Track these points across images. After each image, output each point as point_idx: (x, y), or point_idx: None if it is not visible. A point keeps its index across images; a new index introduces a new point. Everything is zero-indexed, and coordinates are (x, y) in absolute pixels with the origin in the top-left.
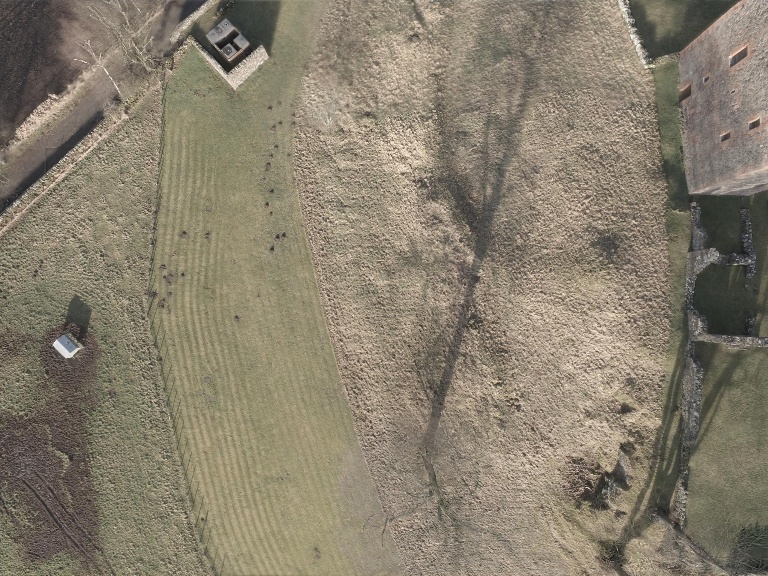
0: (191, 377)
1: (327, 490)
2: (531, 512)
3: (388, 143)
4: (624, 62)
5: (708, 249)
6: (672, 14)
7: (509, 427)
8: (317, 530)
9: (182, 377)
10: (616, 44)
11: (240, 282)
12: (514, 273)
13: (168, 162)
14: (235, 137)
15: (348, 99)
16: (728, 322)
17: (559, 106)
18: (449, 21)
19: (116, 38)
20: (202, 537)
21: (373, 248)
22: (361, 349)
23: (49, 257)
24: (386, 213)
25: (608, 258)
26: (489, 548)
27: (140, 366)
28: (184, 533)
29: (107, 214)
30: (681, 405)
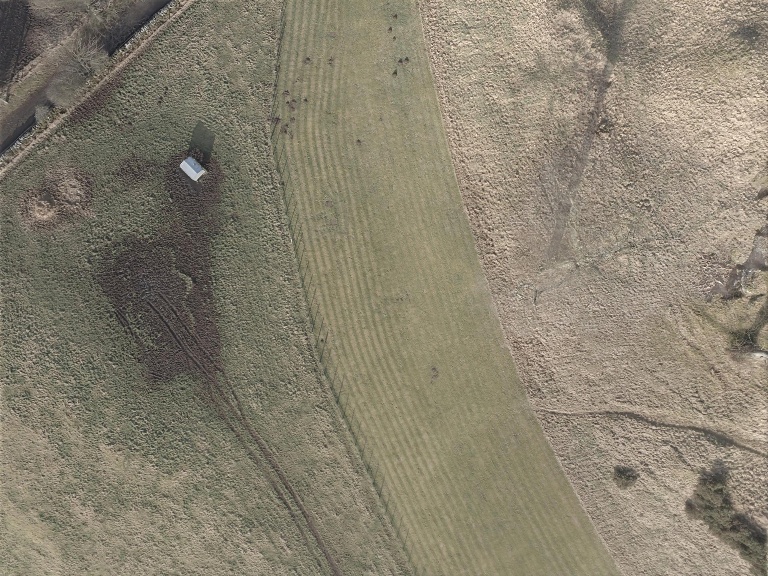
0: (313, 201)
1: (447, 309)
2: (659, 312)
3: None
4: None
5: None
6: None
7: (639, 228)
8: (436, 350)
9: (304, 201)
10: None
11: (362, 107)
12: (647, 74)
13: None
14: None
15: None
16: None
17: None
18: None
19: None
20: (322, 358)
21: (498, 67)
22: (483, 169)
23: (174, 84)
24: (512, 31)
25: (750, 45)
26: (613, 354)
27: (262, 191)
28: (304, 354)
29: (231, 42)
30: None
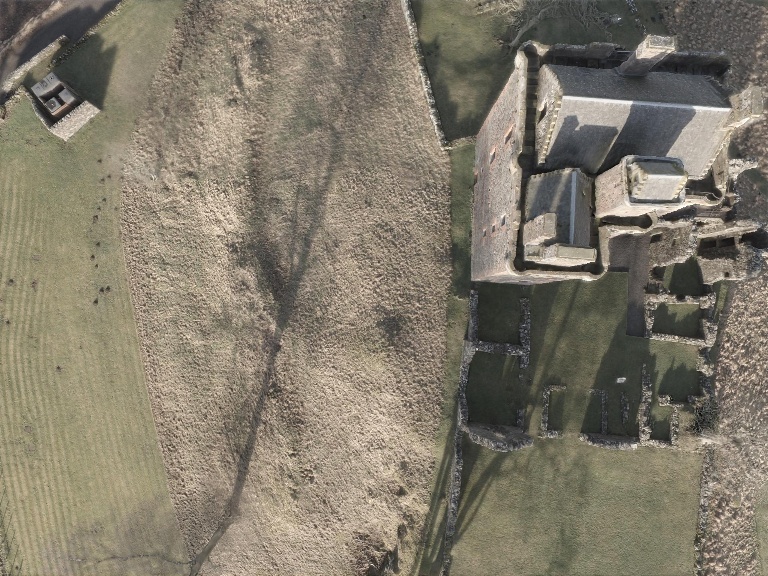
0: (12, 425)
1: (139, 546)
2: None
3: (205, 205)
4: (423, 142)
5: (469, 342)
6: (474, 96)
7: (302, 498)
8: None
9: (3, 424)
10: (417, 123)
11: (63, 333)
12: (311, 345)
13: None
14: (64, 188)
15: (173, 157)
16: (500, 412)
17: (359, 182)
18: (267, 87)
19: None
20: None
21: (191, 307)
22: (177, 407)
23: None
24: (204, 274)
25: (389, 340)
26: None
27: None
28: None
29: None
30: (448, 493)
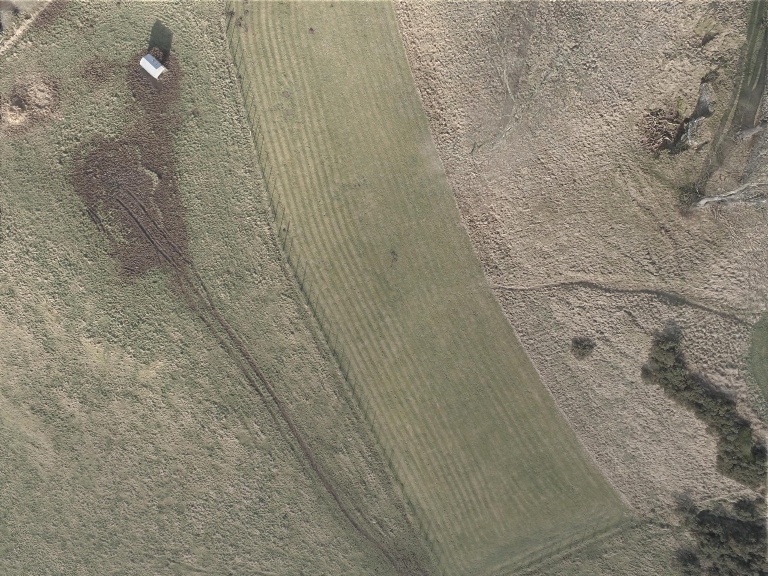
0: (269, 92)
1: (403, 192)
2: (608, 176)
3: None
4: None
5: None
6: None
7: (586, 90)
8: (394, 233)
9: (261, 93)
10: None
11: None
12: None
13: None
14: None
15: None
16: None
17: None
18: None
19: None
20: (285, 247)
21: None
22: (434, 48)
23: None
24: None
25: None
26: (565, 223)
27: (221, 85)
28: (267, 244)
29: None
30: (766, 17)
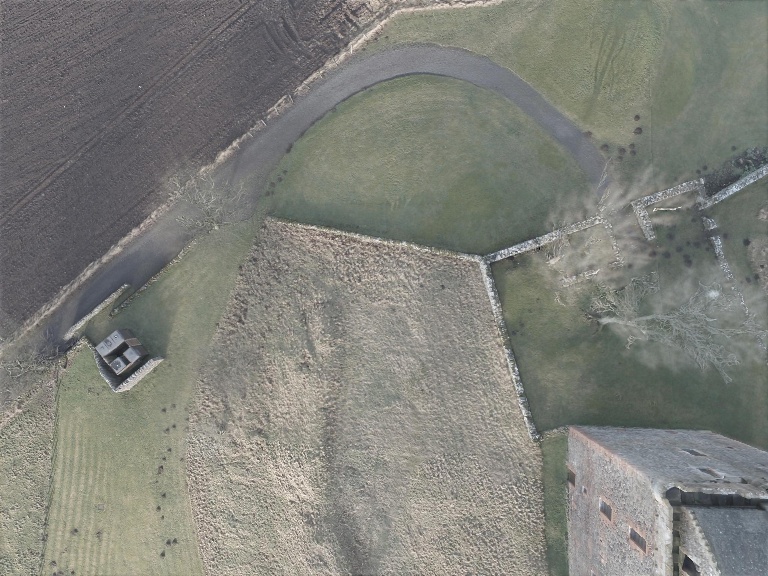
0: None
1: None
2: None
3: (277, 468)
4: (512, 431)
5: None
6: (564, 380)
7: None
8: None
9: None
10: (505, 409)
11: None
12: None
13: (61, 457)
14: (128, 437)
15: (241, 412)
16: None
17: (443, 470)
18: (340, 352)
19: (12, 330)
20: None
21: (262, 568)
22: None
23: None
24: (276, 535)
25: None
26: None
27: None
28: None
29: None
30: None
